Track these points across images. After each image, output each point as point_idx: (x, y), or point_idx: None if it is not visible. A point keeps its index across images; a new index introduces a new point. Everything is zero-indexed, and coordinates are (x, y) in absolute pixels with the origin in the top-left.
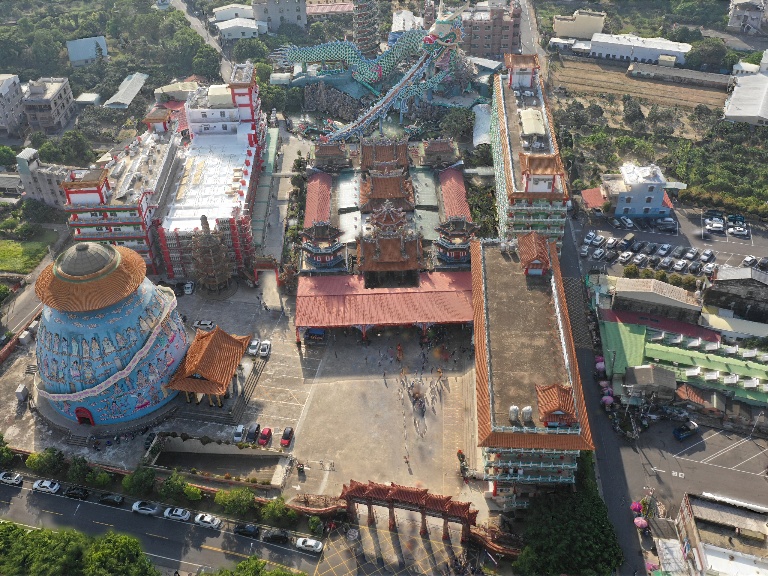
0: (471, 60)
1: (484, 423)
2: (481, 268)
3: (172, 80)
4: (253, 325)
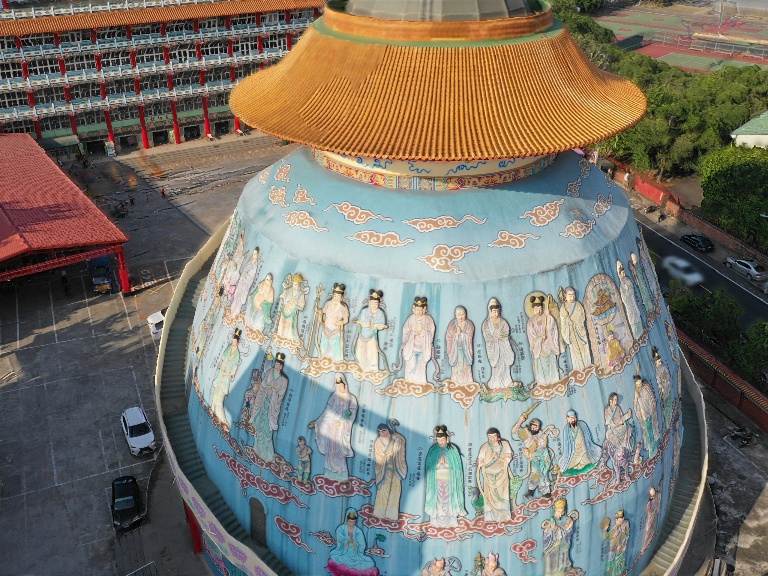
0: None
1: (321, 0)
2: (3, 21)
3: None
4: (93, 368)
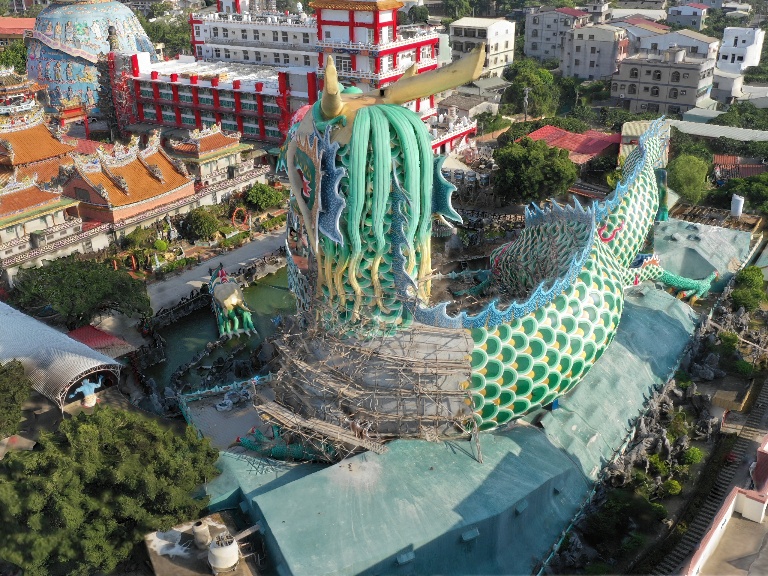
0: (402, 450)
1: None
2: None
3: (765, 160)
4: None
